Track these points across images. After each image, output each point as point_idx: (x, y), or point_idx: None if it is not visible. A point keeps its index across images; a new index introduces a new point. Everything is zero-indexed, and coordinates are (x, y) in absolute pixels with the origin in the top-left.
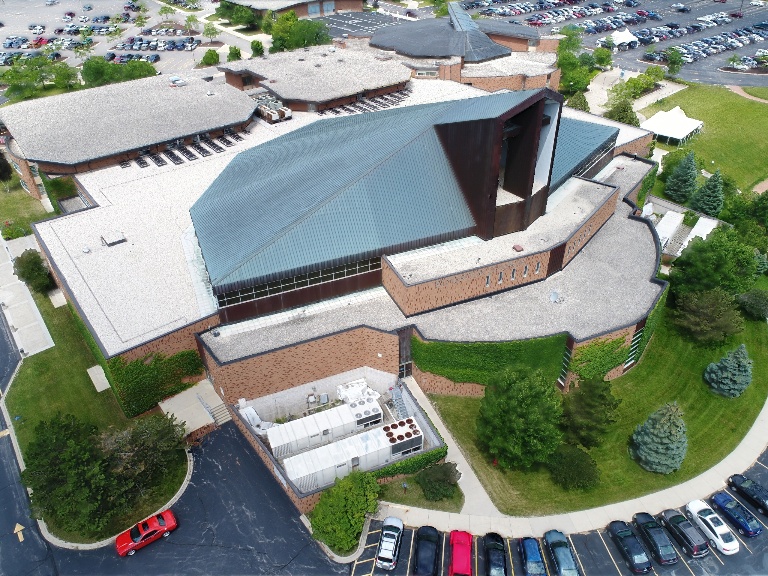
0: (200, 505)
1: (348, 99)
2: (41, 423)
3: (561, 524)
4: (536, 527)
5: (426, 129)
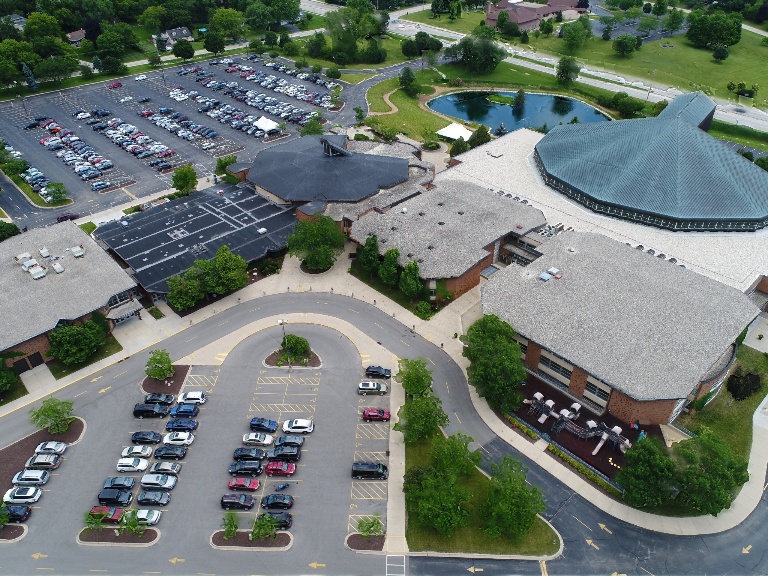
0: None
1: None
2: None
3: None
4: None
5: (701, 129)
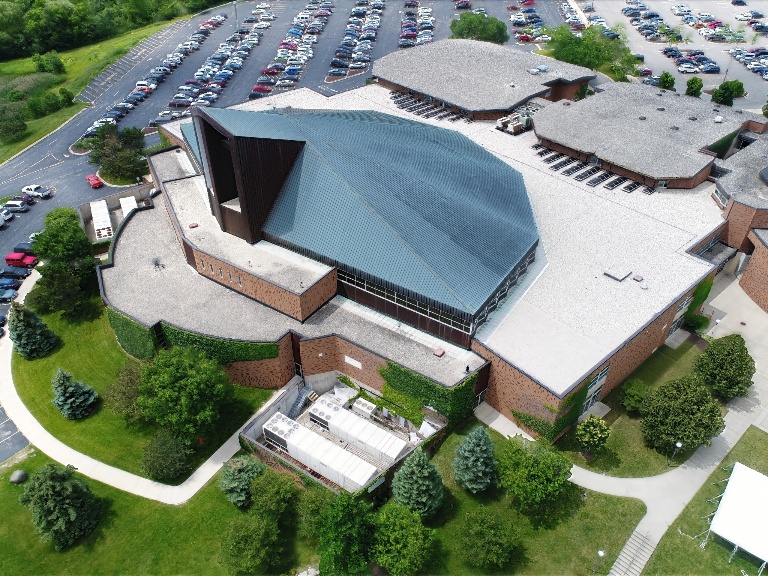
0: (104, 192)
1: (577, 153)
2: (134, 127)
3: (20, 300)
4: (24, 290)
5: None
